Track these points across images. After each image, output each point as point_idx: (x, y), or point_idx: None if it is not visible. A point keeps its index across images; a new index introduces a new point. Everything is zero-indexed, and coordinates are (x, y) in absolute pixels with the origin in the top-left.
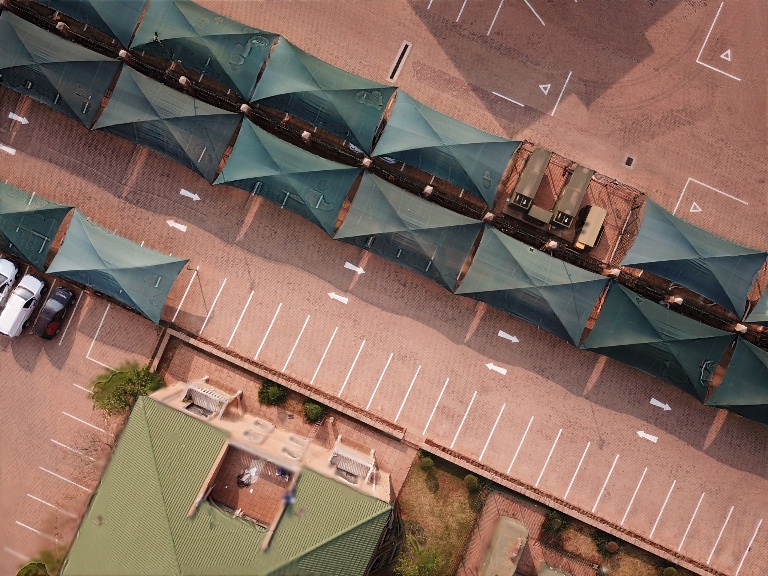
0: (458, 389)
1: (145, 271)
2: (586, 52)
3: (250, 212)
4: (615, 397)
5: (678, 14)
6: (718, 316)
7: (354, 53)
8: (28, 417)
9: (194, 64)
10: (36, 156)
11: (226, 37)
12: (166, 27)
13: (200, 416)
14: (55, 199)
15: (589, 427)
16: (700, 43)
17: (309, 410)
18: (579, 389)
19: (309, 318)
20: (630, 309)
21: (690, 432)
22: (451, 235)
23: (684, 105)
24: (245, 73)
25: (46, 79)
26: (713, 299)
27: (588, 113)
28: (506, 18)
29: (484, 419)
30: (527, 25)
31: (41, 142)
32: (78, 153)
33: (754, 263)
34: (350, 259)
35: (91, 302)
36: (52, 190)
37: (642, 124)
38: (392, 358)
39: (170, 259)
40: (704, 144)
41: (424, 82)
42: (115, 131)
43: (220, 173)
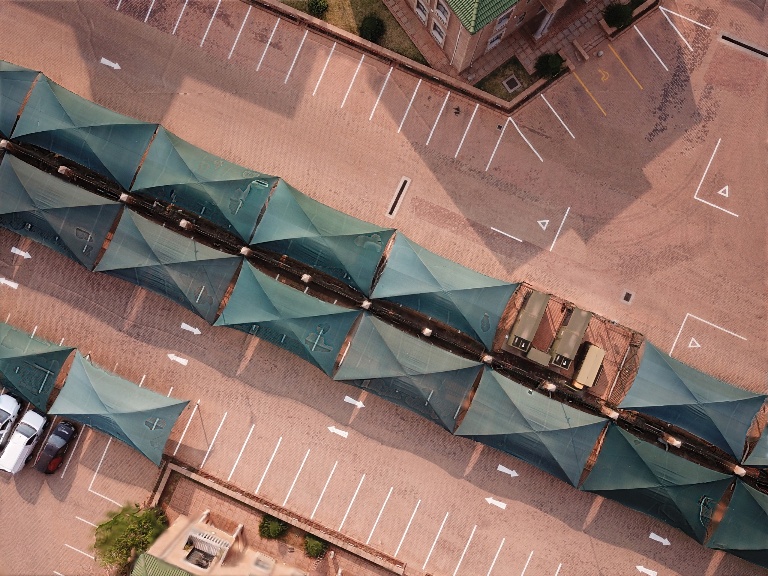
0: (458, 523)
1: (146, 415)
2: (584, 188)
3: (250, 346)
4: (614, 531)
5: (676, 150)
6: (717, 458)
7: (353, 189)
8: (31, 549)
9: (194, 200)
10: (38, 290)
11: (226, 183)
12: (167, 172)
13: (201, 568)
14: (57, 333)
15: (588, 562)
16: (698, 179)
17: (309, 545)
18: (578, 523)
19: (309, 452)
20: (629, 453)
21: (689, 567)
22: (450, 379)
23: (682, 241)
24: (245, 217)
25: (48, 224)
26: (712, 442)
27: (586, 249)
28: (504, 154)
29: (484, 553)
30: (525, 161)
31: (43, 276)
32: (80, 287)
33: (752, 406)
34: (350, 393)
35: (93, 435)
36: (54, 324)
37: (640, 260)
38: (392, 492)
39: (171, 401)
40: (702, 280)
41: (423, 218)
42: (116, 274)
43: (220, 314)
